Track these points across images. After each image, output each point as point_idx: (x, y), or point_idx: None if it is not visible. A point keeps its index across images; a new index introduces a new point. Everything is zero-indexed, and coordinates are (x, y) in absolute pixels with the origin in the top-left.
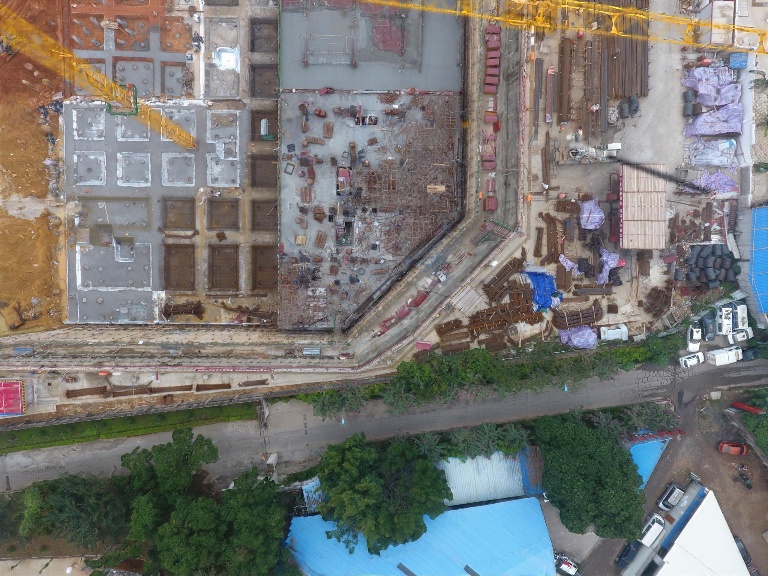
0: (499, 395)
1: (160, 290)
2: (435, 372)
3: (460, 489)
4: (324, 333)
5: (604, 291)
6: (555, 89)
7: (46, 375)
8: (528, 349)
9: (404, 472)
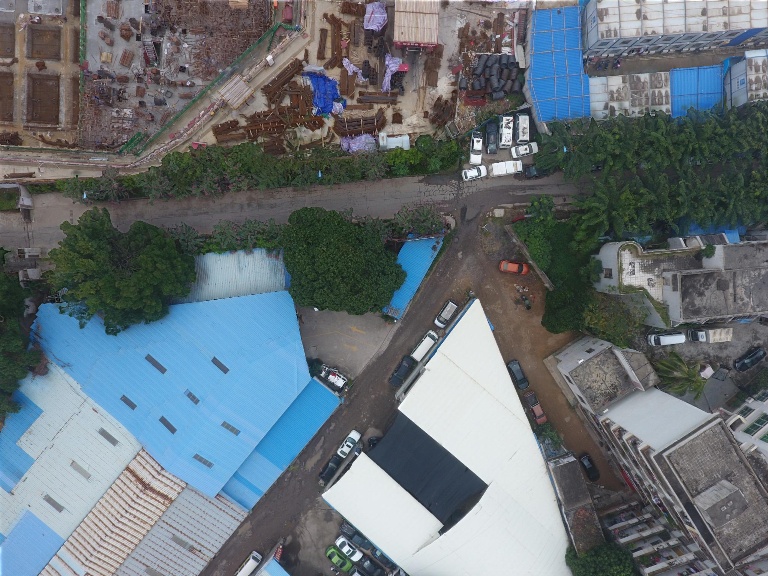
0: (259, 187)
1: None
2: None
3: (220, 286)
4: None
5: (388, 99)
6: None
7: None
8: (306, 154)
9: None
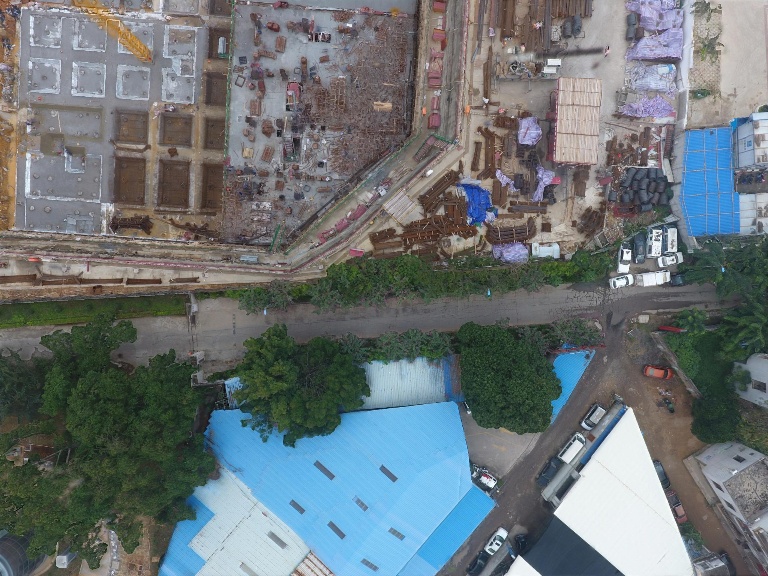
0: (425, 299)
1: (109, 203)
2: (363, 274)
3: (382, 393)
4: (266, 248)
5: (539, 209)
6: (500, 4)
7: None
8: (460, 262)
9: (322, 365)
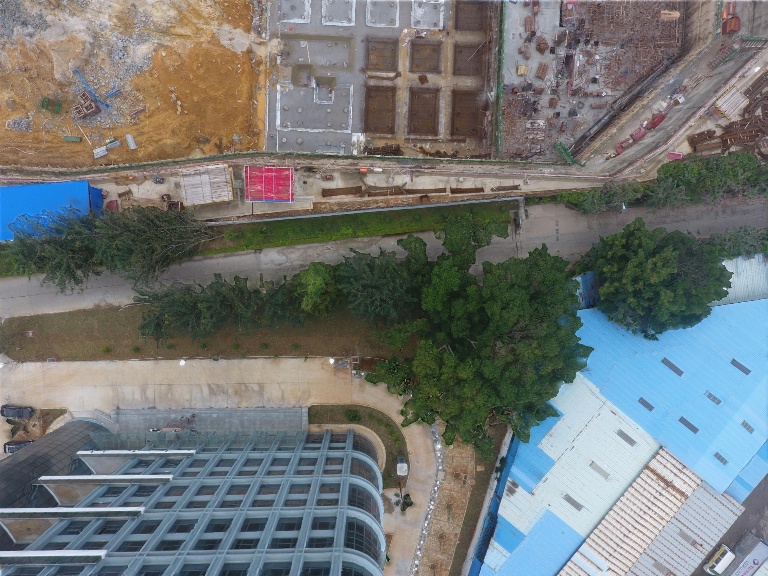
0: (766, 194)
1: (360, 132)
2: None
3: None
4: None
5: None
6: None
7: (302, 173)
8: None
9: (686, 257)
